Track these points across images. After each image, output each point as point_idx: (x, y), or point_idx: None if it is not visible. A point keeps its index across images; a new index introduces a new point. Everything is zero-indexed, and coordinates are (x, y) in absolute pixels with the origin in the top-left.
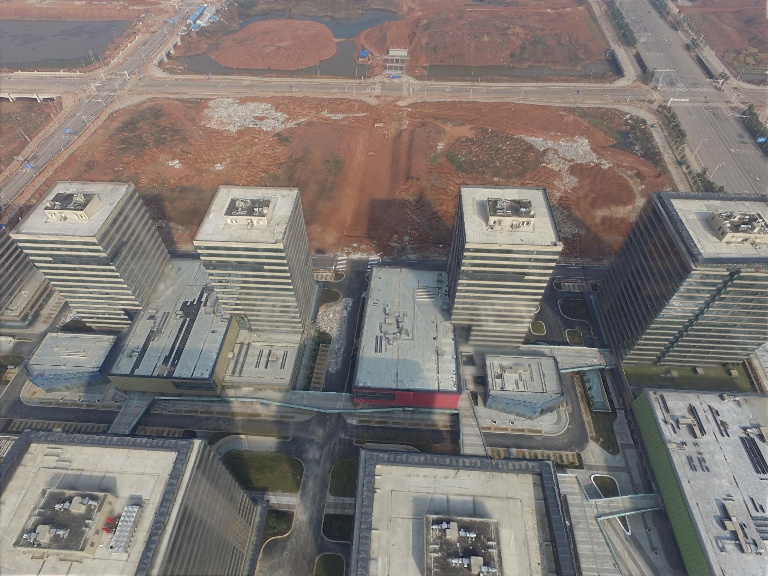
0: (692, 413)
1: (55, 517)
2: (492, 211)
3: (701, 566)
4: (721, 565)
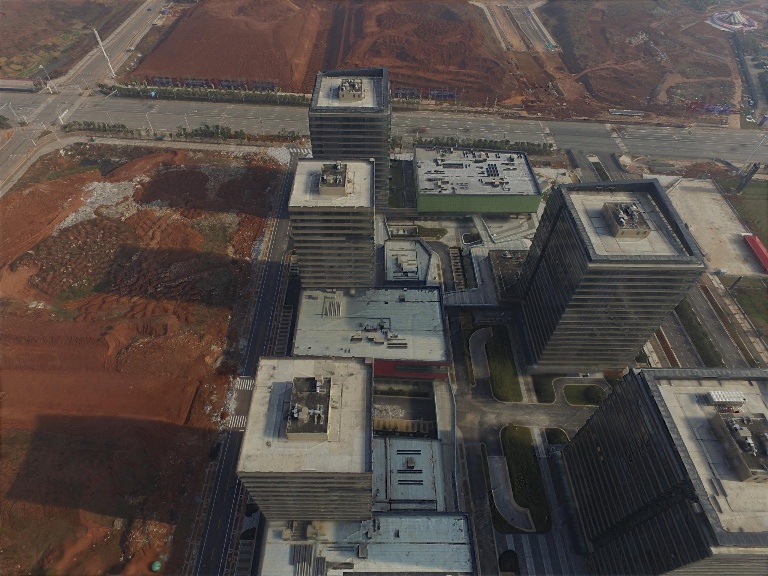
0: (431, 181)
1: (761, 451)
2: (337, 186)
3: (517, 201)
4: (517, 192)
